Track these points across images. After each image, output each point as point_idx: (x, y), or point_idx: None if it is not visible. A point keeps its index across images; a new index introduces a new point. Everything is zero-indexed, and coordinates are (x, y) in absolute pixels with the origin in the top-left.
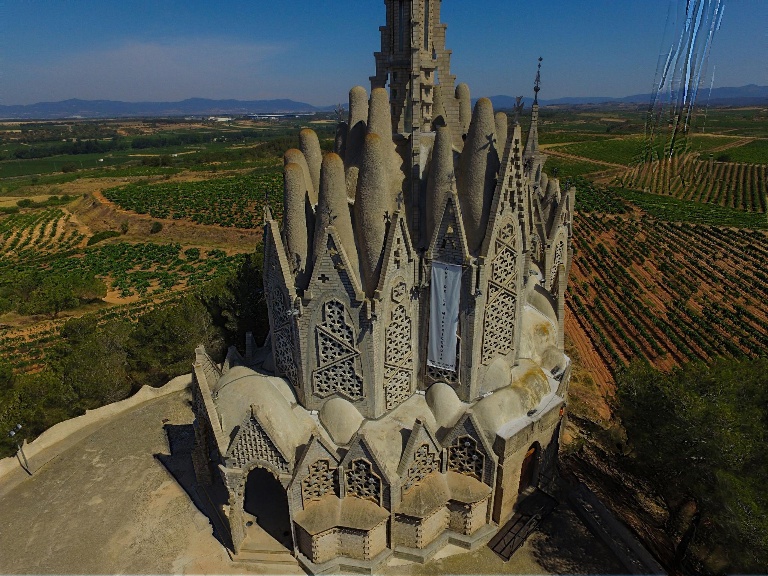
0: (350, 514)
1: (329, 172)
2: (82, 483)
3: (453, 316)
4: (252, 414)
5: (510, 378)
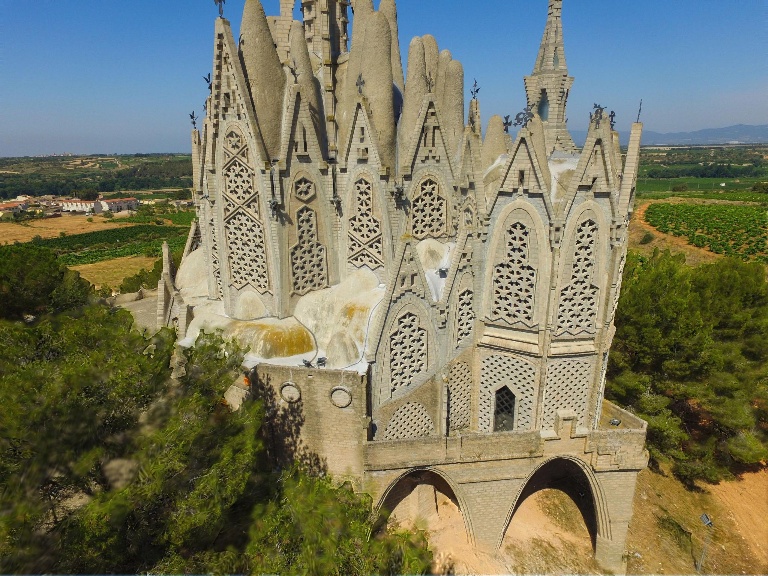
0: None
1: None
2: None
3: None
4: None
5: (250, 317)
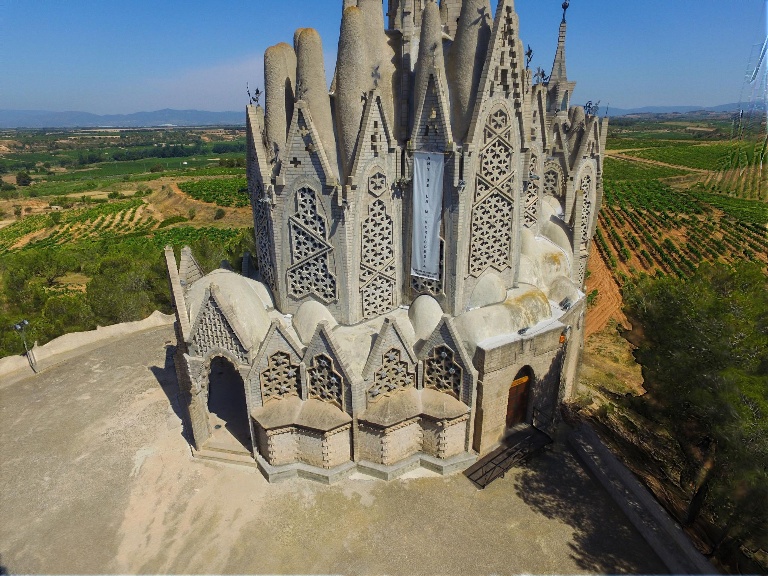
0: (309, 414)
1: (304, 47)
2: (77, 383)
3: (436, 214)
4: (210, 293)
5: (504, 296)
